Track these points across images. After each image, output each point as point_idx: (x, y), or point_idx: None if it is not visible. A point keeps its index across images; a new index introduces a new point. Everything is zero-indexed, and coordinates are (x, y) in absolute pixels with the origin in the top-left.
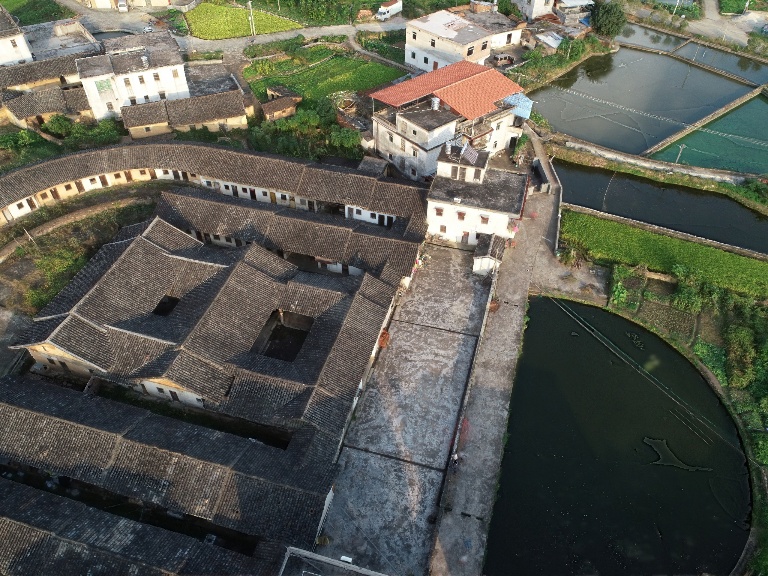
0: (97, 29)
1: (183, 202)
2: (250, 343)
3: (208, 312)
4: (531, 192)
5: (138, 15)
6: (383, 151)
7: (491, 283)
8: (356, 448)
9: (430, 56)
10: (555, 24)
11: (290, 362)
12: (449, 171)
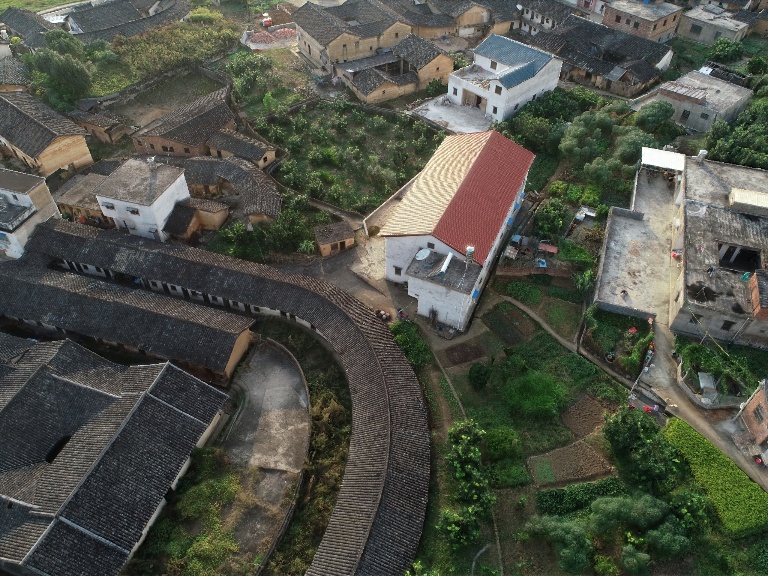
0: None
1: None
2: None
3: (7, 405)
4: None
5: None
6: None
7: None
8: None
9: None
10: None
11: None
12: None
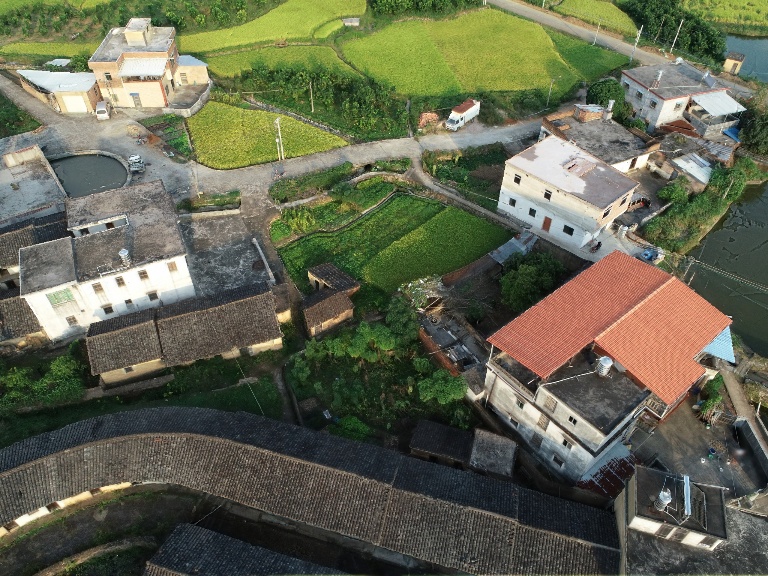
0: (65, 151)
1: None
2: None
3: None
4: (752, 499)
5: (123, 124)
6: (500, 409)
7: None
8: None
9: (540, 209)
10: (691, 138)
11: None
12: (654, 527)
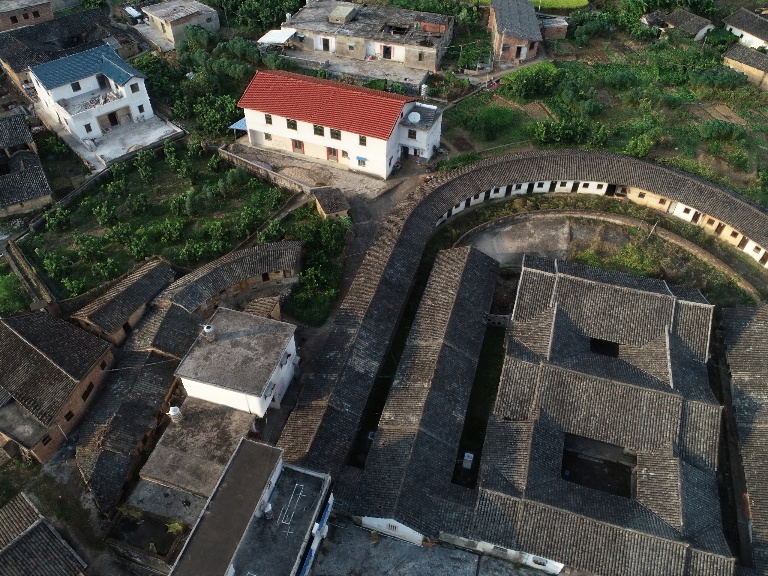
0: None
1: (763, 328)
2: (575, 430)
3: (594, 378)
4: None
5: None
6: None
7: None
8: (478, 570)
9: None
10: None
11: (560, 475)
12: None
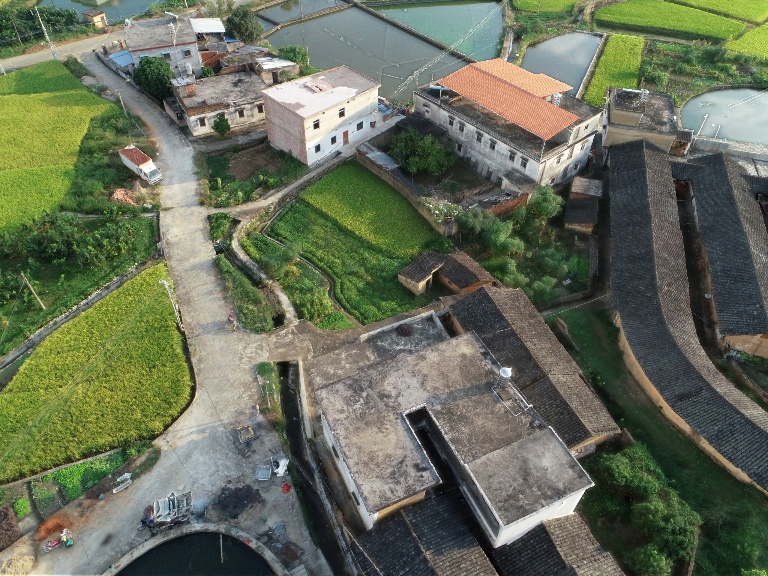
0: None
1: None
2: None
3: None
4: None
5: None
6: (545, 184)
7: (698, 146)
8: None
9: (339, 131)
10: None
11: None
12: None
